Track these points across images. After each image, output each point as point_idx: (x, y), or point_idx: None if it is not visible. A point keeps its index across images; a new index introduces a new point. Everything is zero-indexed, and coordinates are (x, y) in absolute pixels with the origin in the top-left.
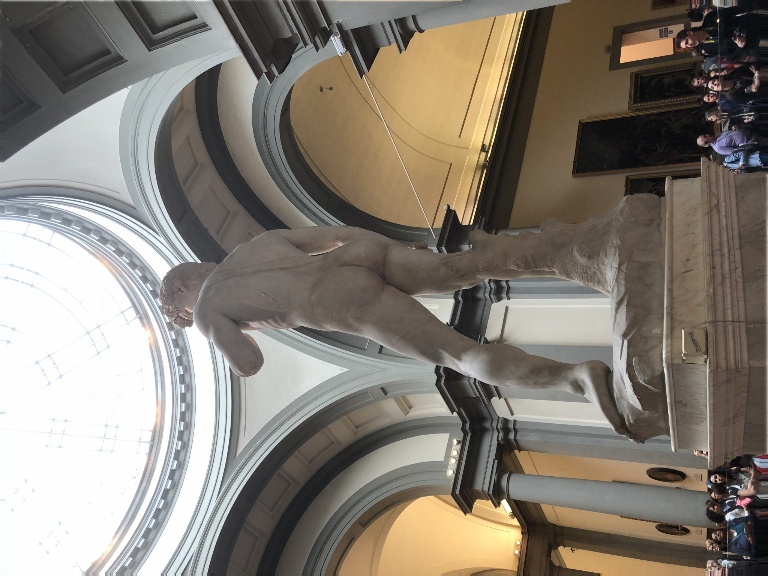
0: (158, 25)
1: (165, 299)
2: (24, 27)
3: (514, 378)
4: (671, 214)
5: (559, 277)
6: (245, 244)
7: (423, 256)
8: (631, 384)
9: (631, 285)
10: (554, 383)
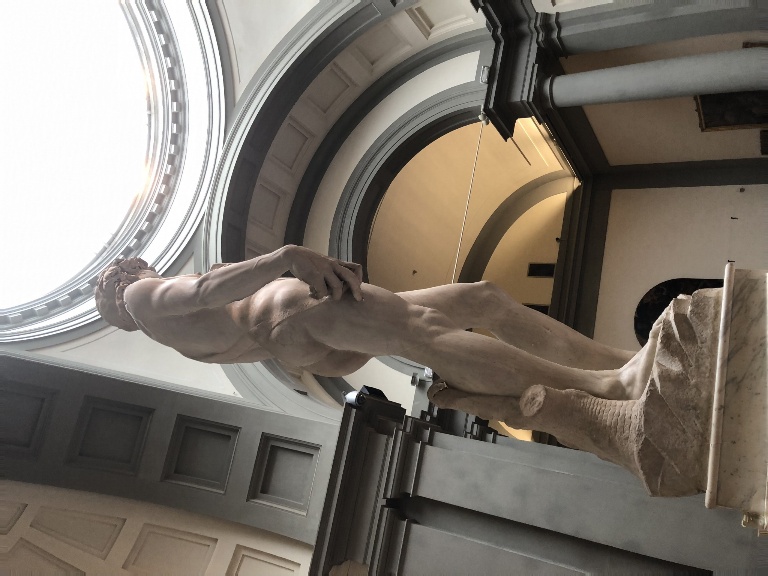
0: None
1: None
2: None
3: None
4: None
5: None
6: None
7: None
8: None
9: None
10: None
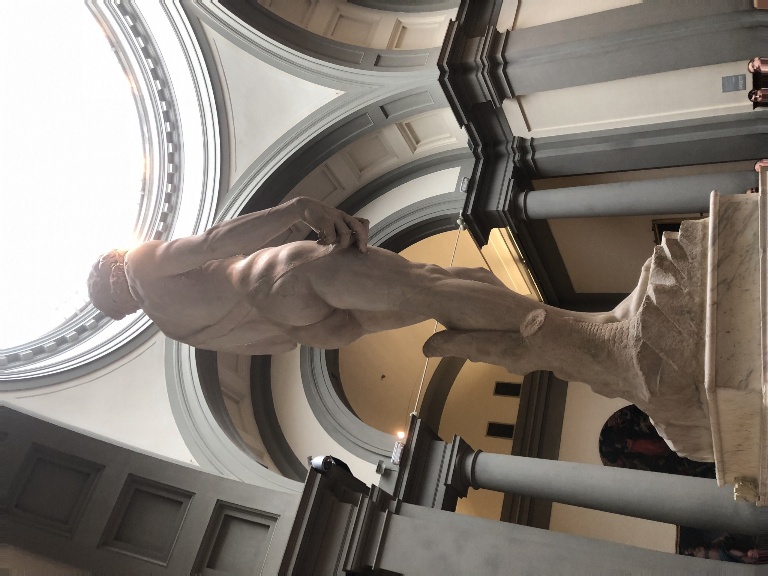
0: None
1: None
2: None
3: None
4: (716, 418)
5: None
6: (148, 307)
7: (374, 306)
8: None
9: None
10: None
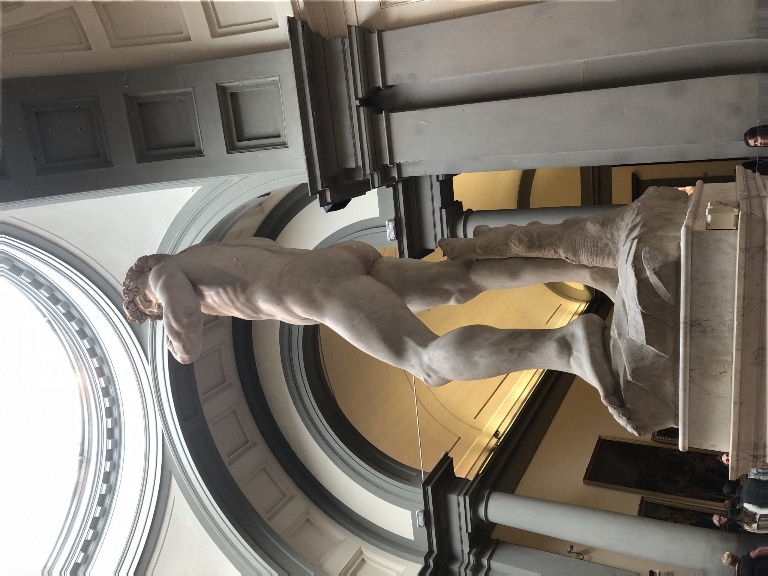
0: (245, 136)
1: (131, 273)
2: (136, 99)
3: (486, 345)
4: (701, 189)
5: (563, 275)
6: None
7: None
8: (636, 283)
9: (648, 217)
10: (535, 347)
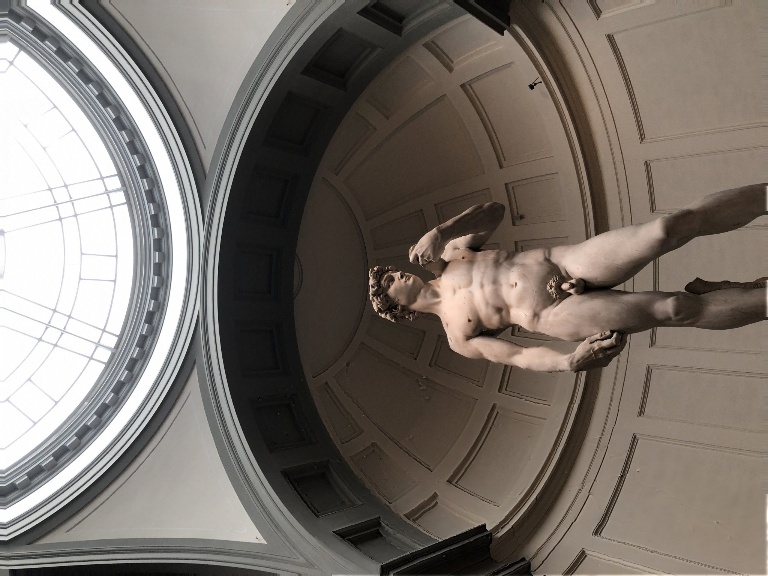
0: None
1: None
2: None
3: None
4: None
5: None
6: None
7: None
8: None
9: None
10: None
